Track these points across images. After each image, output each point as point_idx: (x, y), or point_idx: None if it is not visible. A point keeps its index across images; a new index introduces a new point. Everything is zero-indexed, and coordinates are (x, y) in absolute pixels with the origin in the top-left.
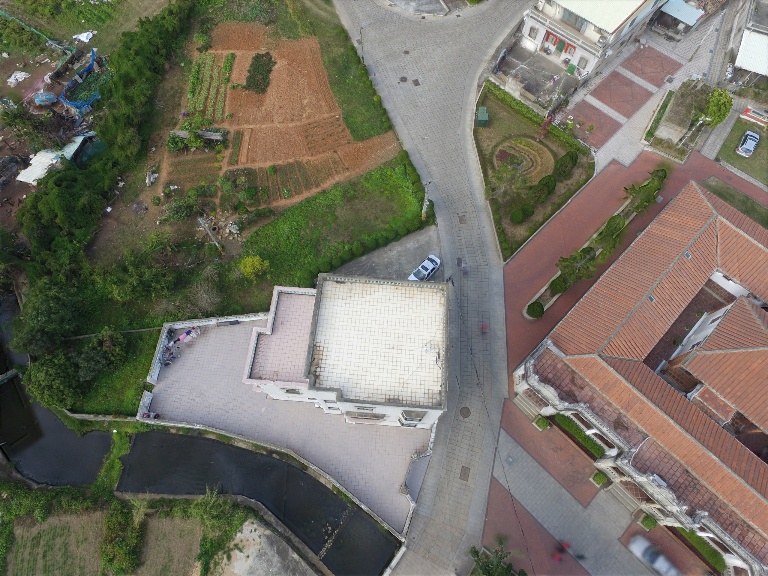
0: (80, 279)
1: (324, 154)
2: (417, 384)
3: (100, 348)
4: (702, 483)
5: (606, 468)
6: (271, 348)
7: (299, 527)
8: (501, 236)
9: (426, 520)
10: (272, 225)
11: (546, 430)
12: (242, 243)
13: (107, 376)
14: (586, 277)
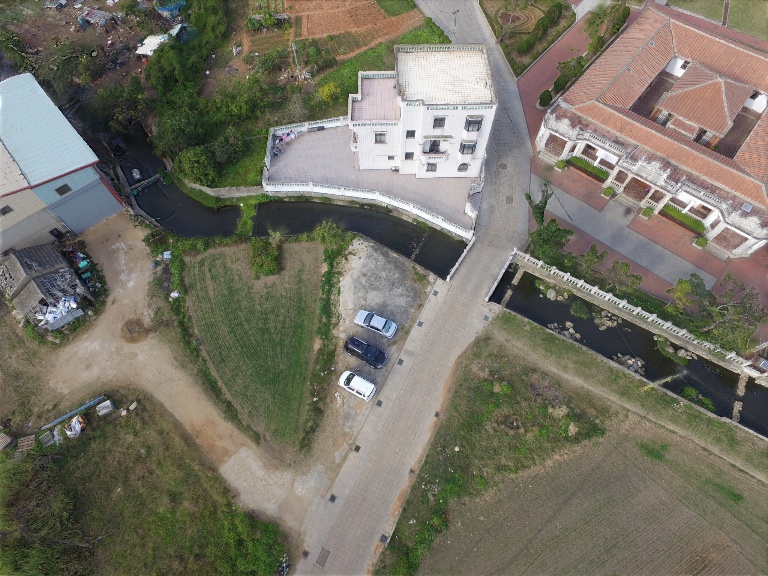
0: (198, 111)
1: (367, 26)
2: (474, 98)
3: (227, 143)
4: (680, 167)
5: (612, 184)
6: (363, 108)
7: (392, 246)
8: (512, 61)
9: (486, 227)
10: (336, 71)
11: (565, 171)
12: (315, 84)
13: (232, 166)
14: (580, 73)
